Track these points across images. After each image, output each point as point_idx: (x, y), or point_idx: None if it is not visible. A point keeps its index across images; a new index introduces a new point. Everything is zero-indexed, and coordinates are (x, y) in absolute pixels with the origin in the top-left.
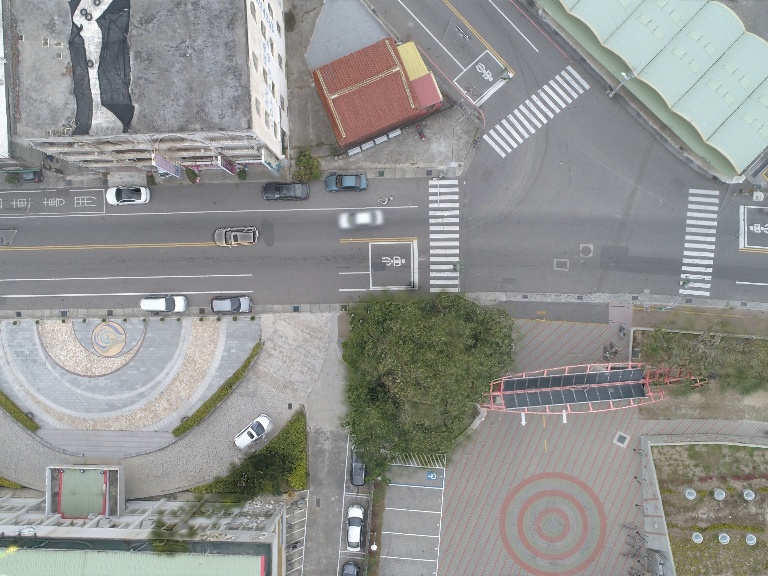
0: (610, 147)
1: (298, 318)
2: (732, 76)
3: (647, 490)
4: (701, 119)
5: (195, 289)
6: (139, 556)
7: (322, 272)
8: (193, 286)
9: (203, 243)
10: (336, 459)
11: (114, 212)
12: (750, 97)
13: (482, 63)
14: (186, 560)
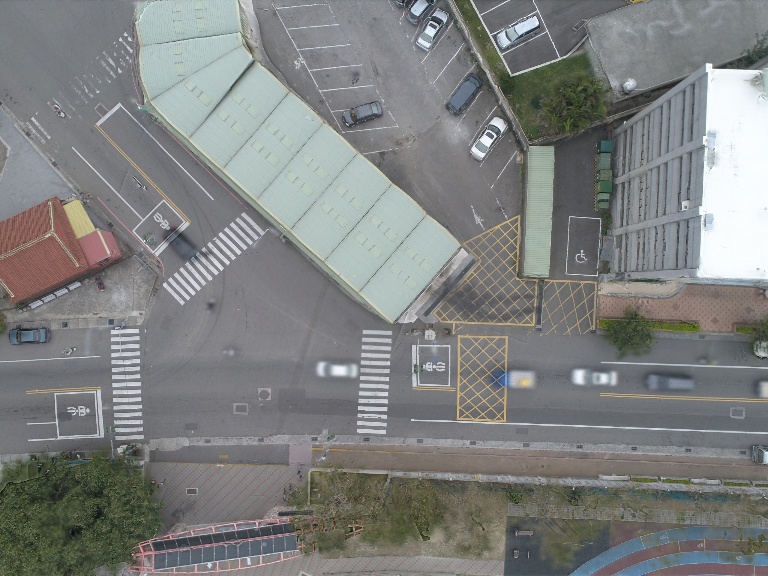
0: (285, 292)
1: None
2: (378, 229)
3: None
4: (350, 272)
5: None
6: None
7: (10, 423)
8: None
9: None
10: None
11: None
12: (399, 248)
13: (159, 213)
14: None
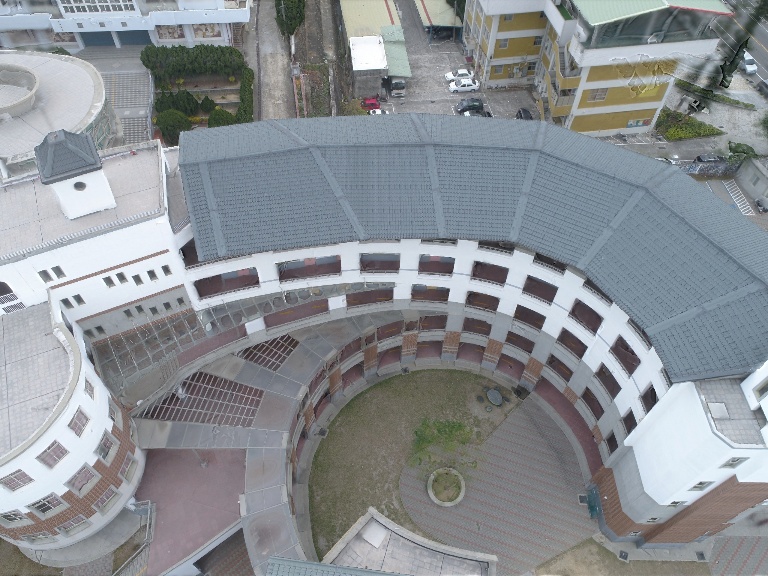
0: None
1: None
2: None
3: None
4: None
5: (763, 77)
6: None
7: None
8: (765, 76)
9: None
10: None
11: None
12: None
13: None
14: None
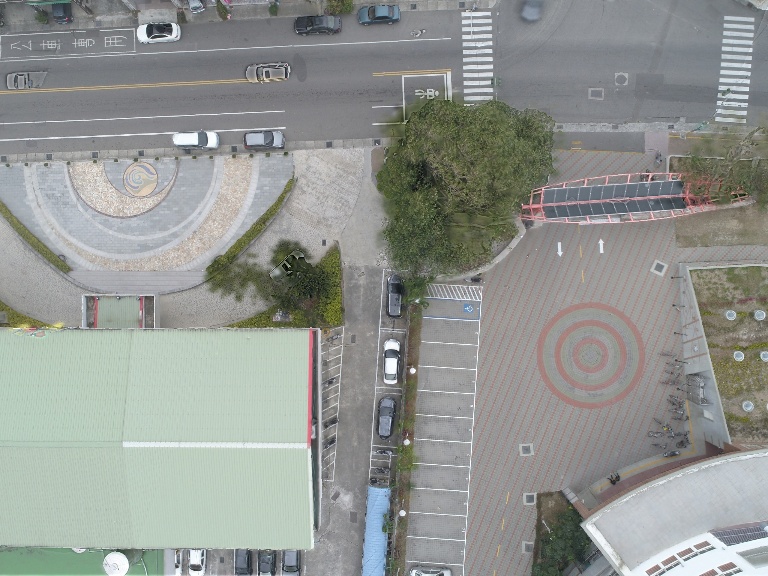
0: None
1: (331, 154)
2: None
3: (686, 316)
4: None
5: (227, 127)
6: (186, 333)
7: (355, 106)
8: (225, 124)
9: (235, 80)
10: (371, 294)
11: (144, 51)
12: None
13: None
14: (233, 336)
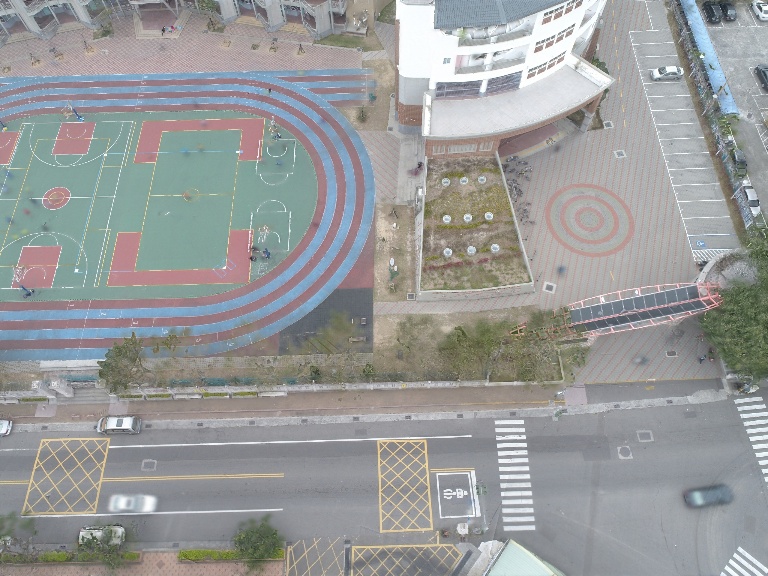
0: (629, 570)
1: None
2: None
3: None
4: None
5: None
6: None
7: None
8: None
9: None
10: None
11: None
12: None
13: None
14: None
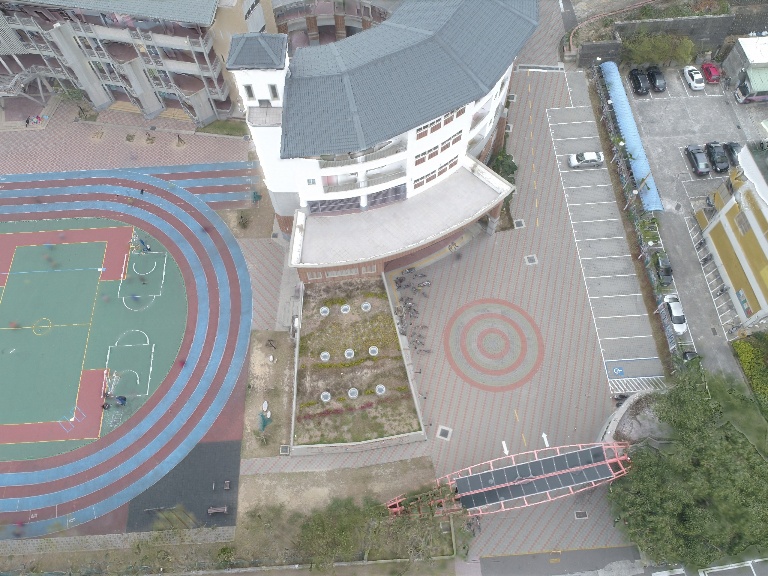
0: None
1: None
2: None
3: (416, 388)
4: None
5: None
6: None
7: None
8: None
9: None
10: (714, 374)
11: None
12: None
13: None
14: None
